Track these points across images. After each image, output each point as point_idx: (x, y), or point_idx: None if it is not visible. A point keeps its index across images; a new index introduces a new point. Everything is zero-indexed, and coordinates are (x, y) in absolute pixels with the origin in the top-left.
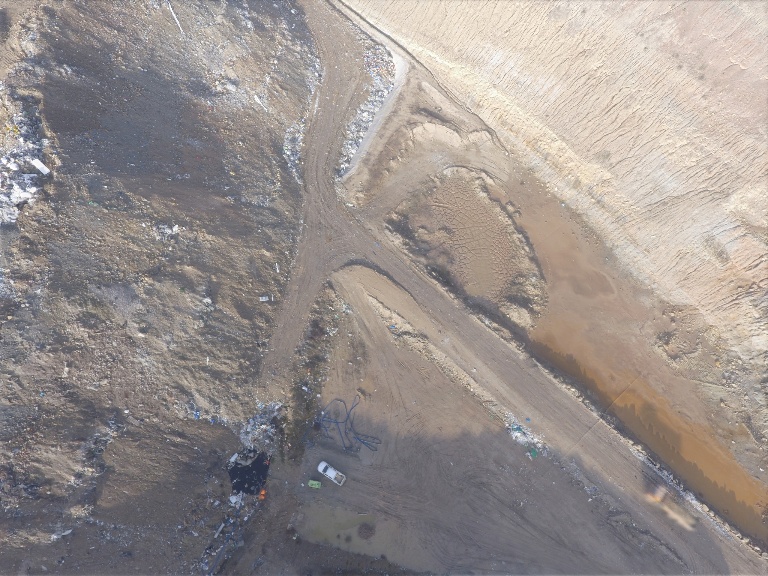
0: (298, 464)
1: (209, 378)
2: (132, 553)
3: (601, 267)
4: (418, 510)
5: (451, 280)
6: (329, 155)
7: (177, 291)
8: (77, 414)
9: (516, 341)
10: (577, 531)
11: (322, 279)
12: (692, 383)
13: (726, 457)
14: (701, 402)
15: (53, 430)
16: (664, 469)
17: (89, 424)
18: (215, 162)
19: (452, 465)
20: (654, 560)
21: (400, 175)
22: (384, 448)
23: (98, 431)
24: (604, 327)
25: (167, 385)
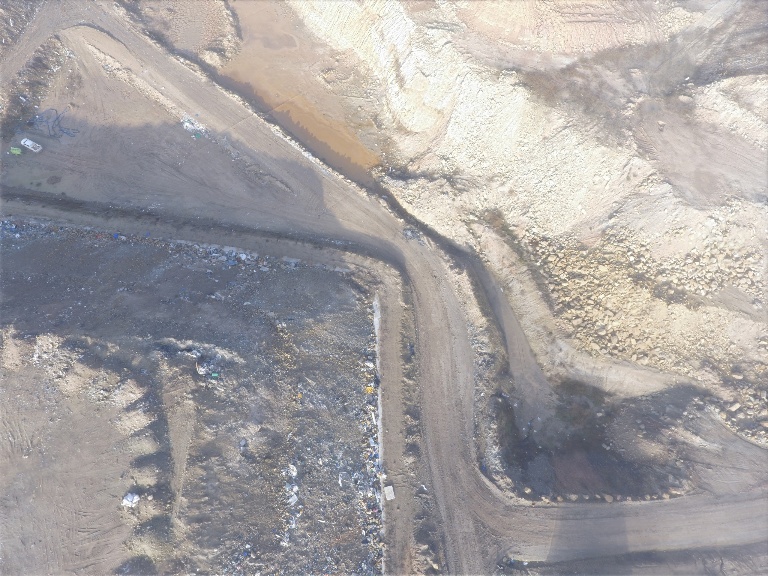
0: (7, 142)
1: None
2: None
3: (291, 31)
4: (98, 168)
5: (164, 39)
6: None
7: None
8: None
9: (201, 71)
10: (217, 177)
11: (51, 33)
12: (340, 98)
13: (352, 139)
14: (343, 108)
15: None
16: None
17: None
18: None
19: (132, 144)
20: (270, 191)
21: None
22: (81, 135)
23: None
24: (281, 66)
25: None
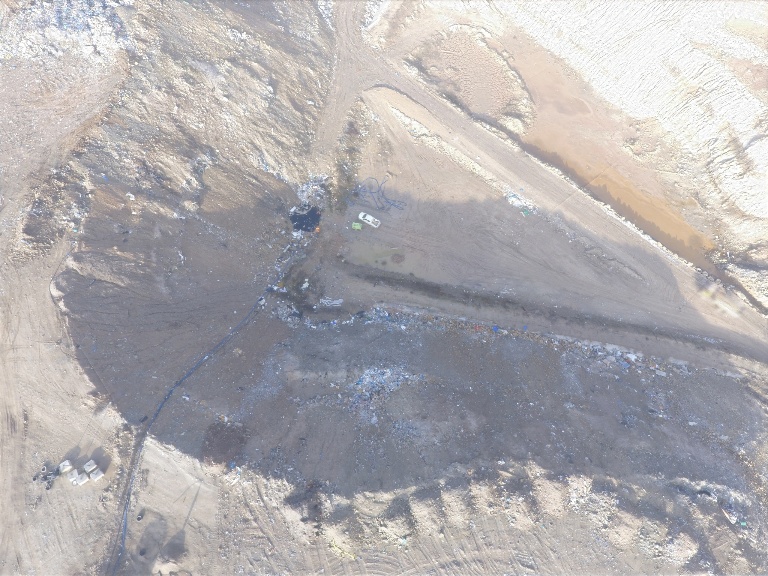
0: (343, 215)
1: (274, 143)
2: (227, 246)
3: (580, 95)
4: (437, 246)
5: (458, 102)
6: (356, 11)
7: (248, 77)
8: (185, 141)
9: (511, 139)
10: (560, 260)
11: (355, 95)
12: (652, 172)
13: (678, 219)
14: (659, 184)
15: (170, 145)
16: (628, 221)
17: (193, 150)
18: (267, 2)
19: (462, 219)
20: (619, 277)
21: (414, 30)
22: (409, 208)
23: (199, 157)
24: (582, 135)
25: (245, 140)
